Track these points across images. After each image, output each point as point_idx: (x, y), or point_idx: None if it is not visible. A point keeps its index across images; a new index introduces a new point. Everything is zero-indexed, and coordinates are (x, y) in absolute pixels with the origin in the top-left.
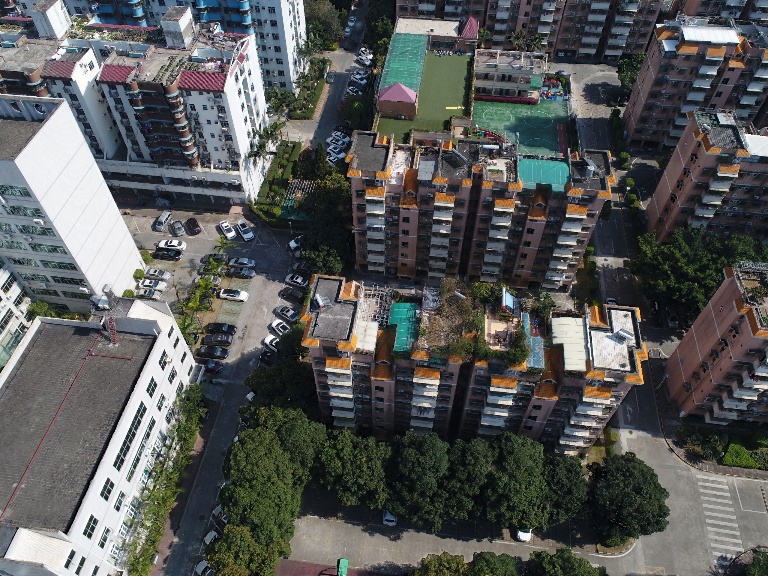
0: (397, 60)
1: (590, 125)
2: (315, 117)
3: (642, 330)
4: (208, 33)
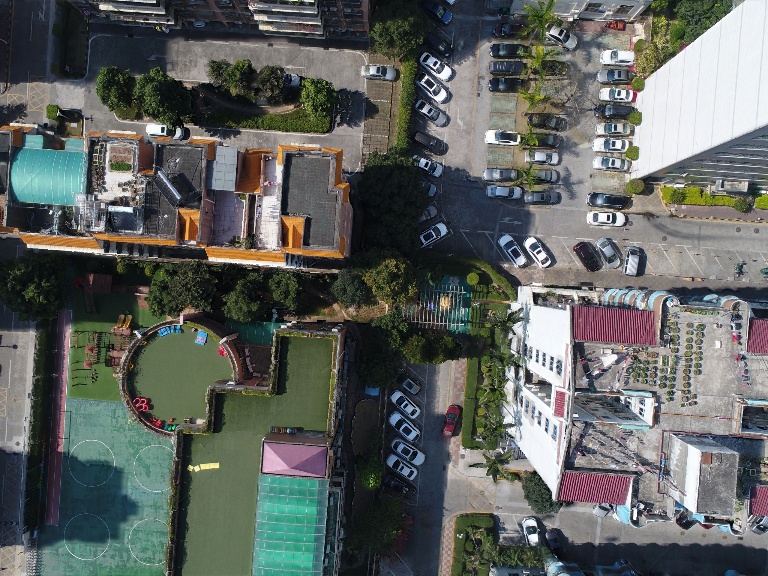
0: (301, 574)
1: (6, 526)
2: (452, 523)
3: (7, 122)
4: (646, 500)
